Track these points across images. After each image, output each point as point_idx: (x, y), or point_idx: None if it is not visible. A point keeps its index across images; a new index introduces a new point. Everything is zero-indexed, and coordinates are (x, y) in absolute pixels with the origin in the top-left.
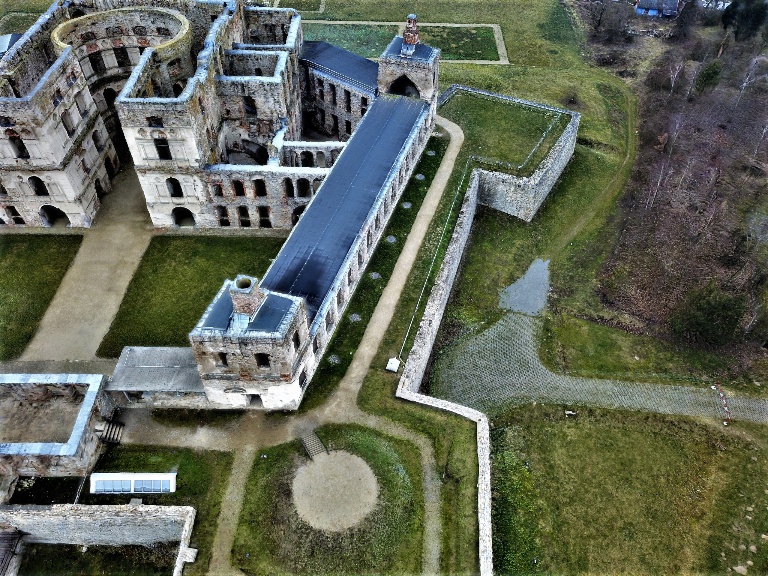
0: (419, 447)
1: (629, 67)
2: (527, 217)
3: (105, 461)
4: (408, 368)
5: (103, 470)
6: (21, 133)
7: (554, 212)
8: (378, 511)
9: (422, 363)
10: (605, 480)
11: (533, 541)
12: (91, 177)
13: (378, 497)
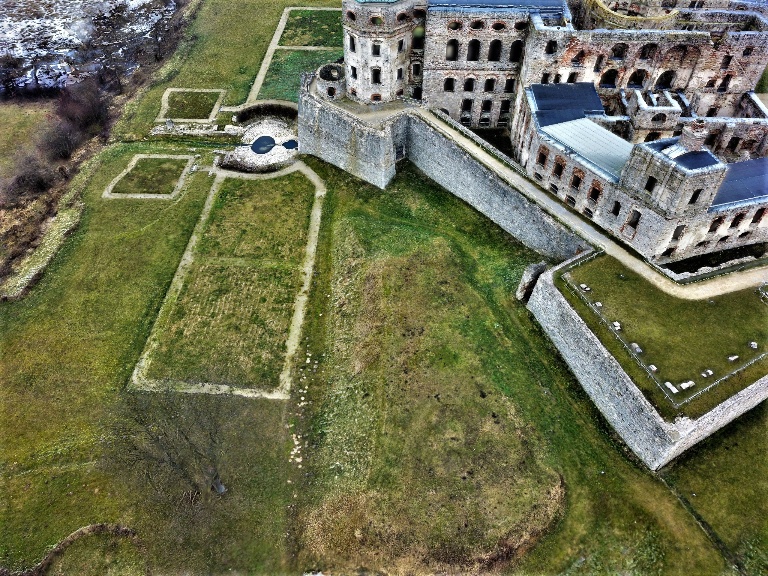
0: None
1: None
2: None
3: None
4: None
5: None
6: None
7: None
8: None
9: None
10: None
11: None
12: None
13: None
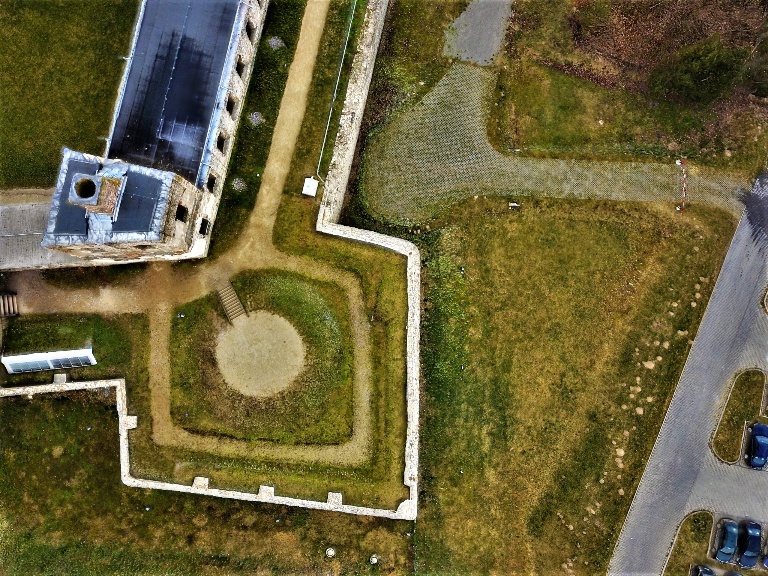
0: (346, 289)
1: None
2: None
3: (11, 339)
4: (328, 189)
5: (12, 352)
6: None
7: None
8: (306, 371)
9: (347, 165)
10: (540, 280)
11: (462, 348)
12: None
13: (305, 358)
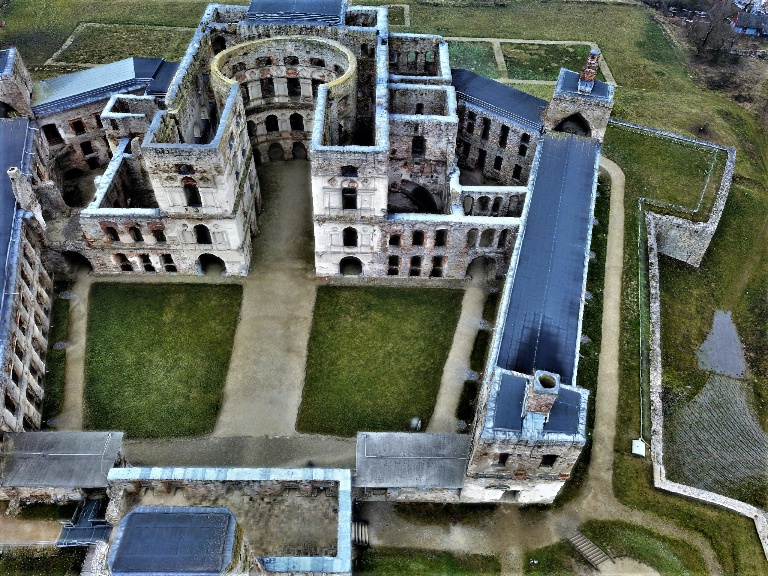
0: (698, 549)
1: (742, 91)
2: (697, 263)
3: (362, 570)
4: (656, 451)
5: None
6: (199, 181)
7: (719, 256)
8: None
9: None
10: None
11: None
12: (248, 221)
13: None
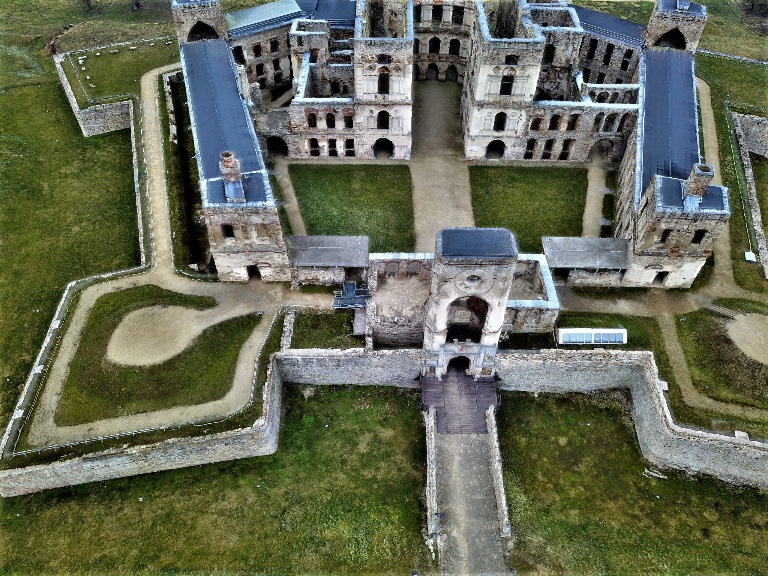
0: None
1: None
2: None
3: (559, 322)
4: (764, 259)
5: (565, 326)
6: (392, 70)
7: None
8: None
9: None
10: None
11: None
12: None
13: None
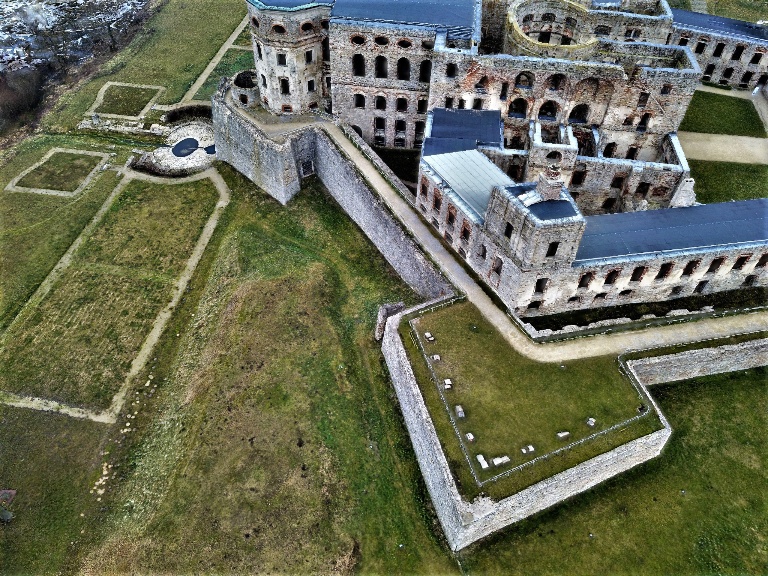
0: None
1: None
2: None
3: None
4: None
5: None
6: None
7: None
8: None
9: None
10: None
11: None
12: None
13: None
